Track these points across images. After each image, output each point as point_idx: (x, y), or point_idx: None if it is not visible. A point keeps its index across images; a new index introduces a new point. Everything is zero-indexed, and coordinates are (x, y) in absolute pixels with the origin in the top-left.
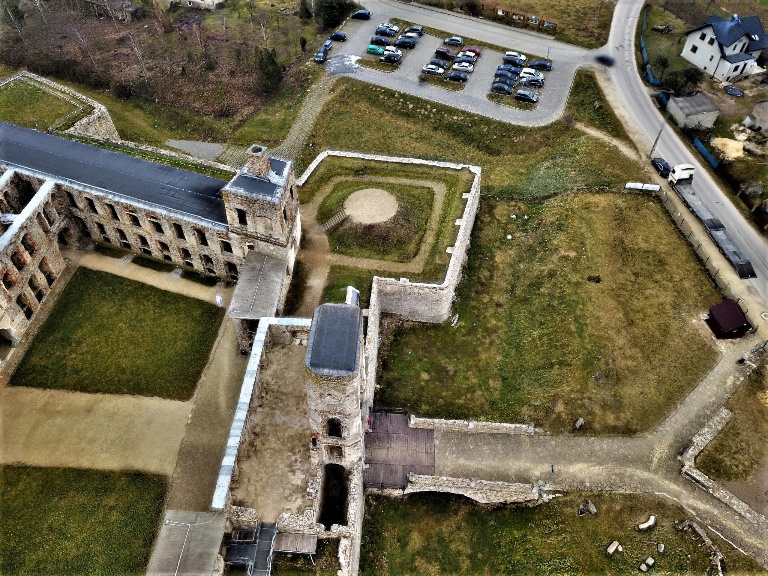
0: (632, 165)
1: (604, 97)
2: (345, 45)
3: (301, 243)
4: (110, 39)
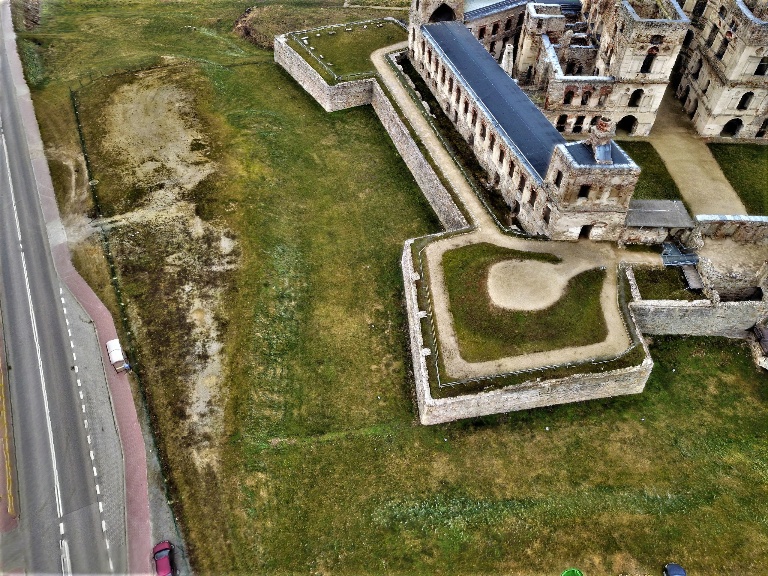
0: None
1: None
2: None
3: None
4: None
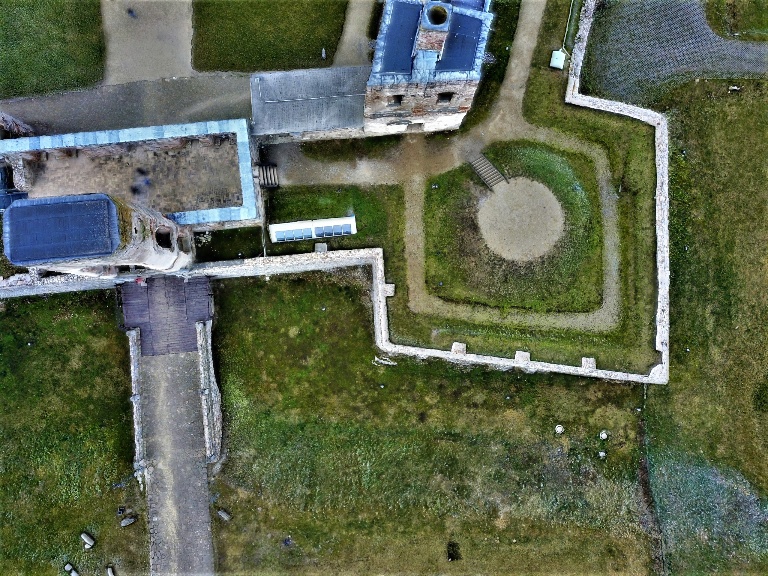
0: None
1: None
2: None
3: (437, 133)
4: None
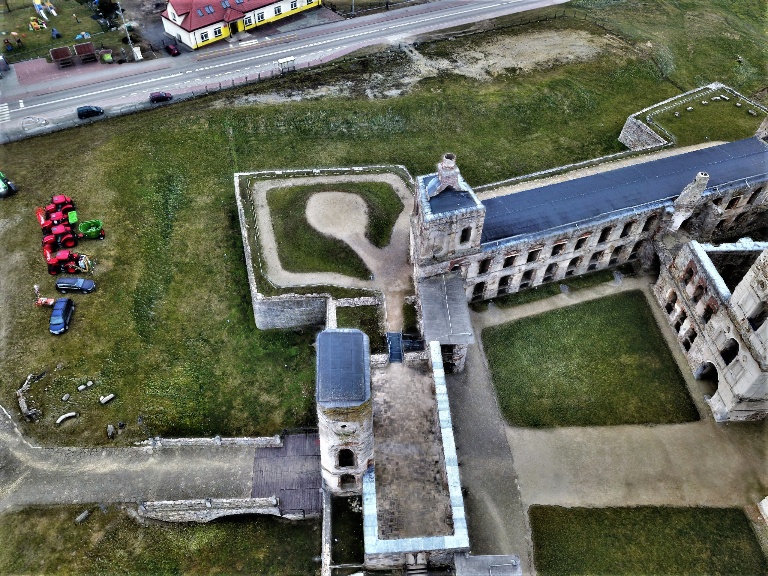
0: None
1: None
2: None
3: None
4: None
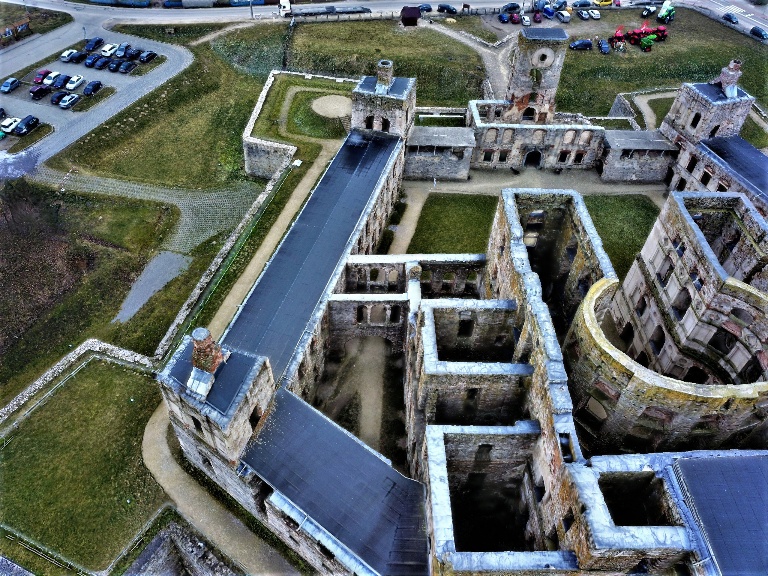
0: (261, 26)
1: (163, 25)
2: None
3: None
4: None
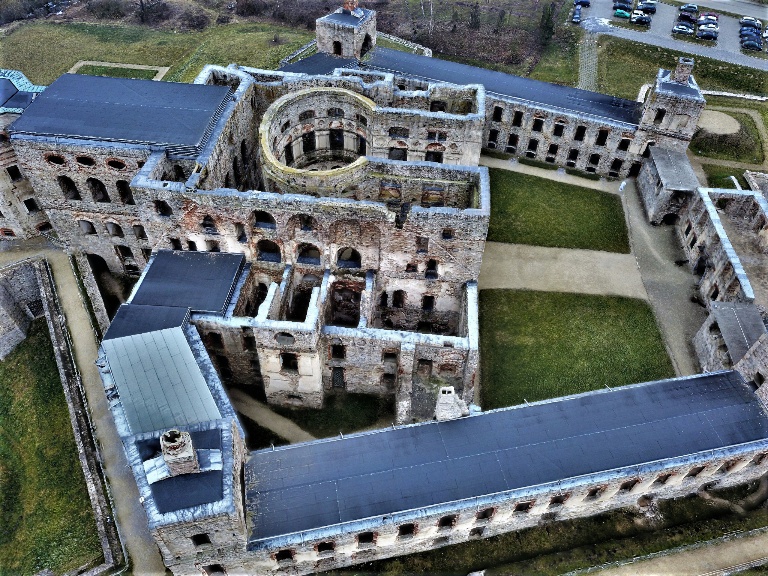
0: None
1: None
2: (591, 10)
3: None
4: (368, 3)
